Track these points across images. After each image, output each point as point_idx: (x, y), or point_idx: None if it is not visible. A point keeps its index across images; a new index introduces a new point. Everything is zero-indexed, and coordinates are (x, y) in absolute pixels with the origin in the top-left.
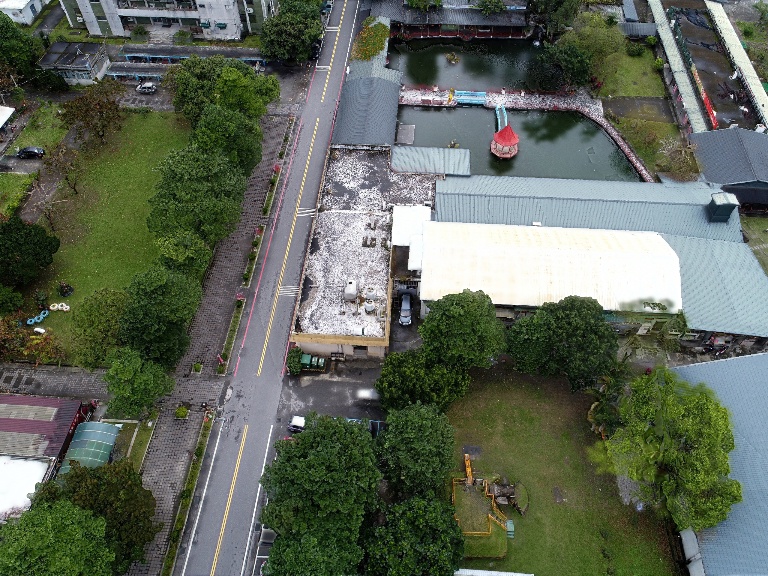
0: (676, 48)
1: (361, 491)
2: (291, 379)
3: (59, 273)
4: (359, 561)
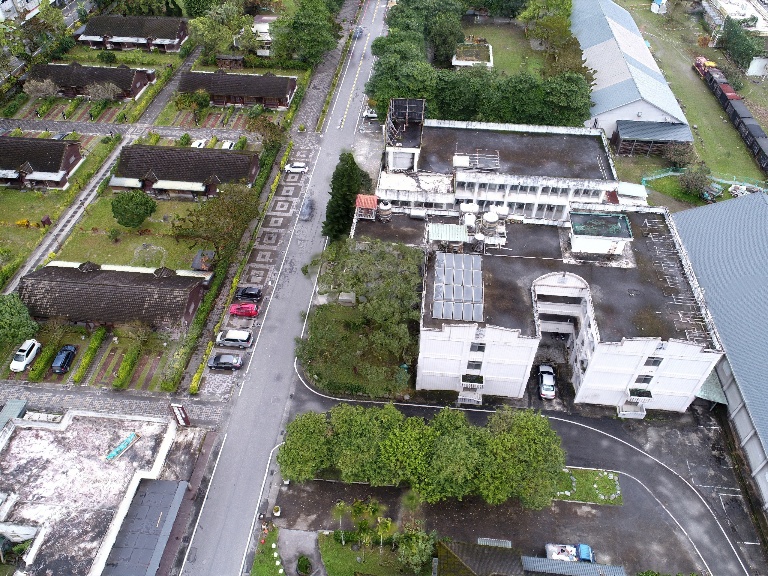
0: None
1: (425, 9)
2: None
3: None
4: (425, 23)
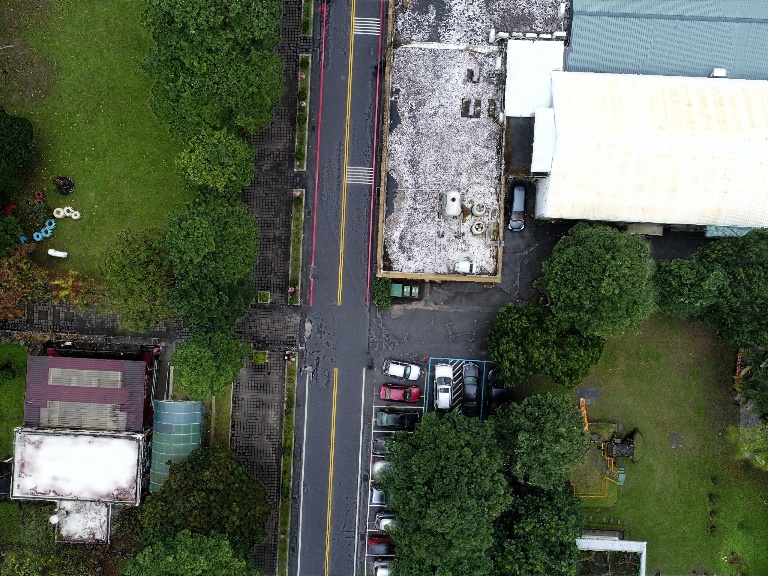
0: None
1: None
2: (379, 309)
3: (44, 154)
4: (489, 572)
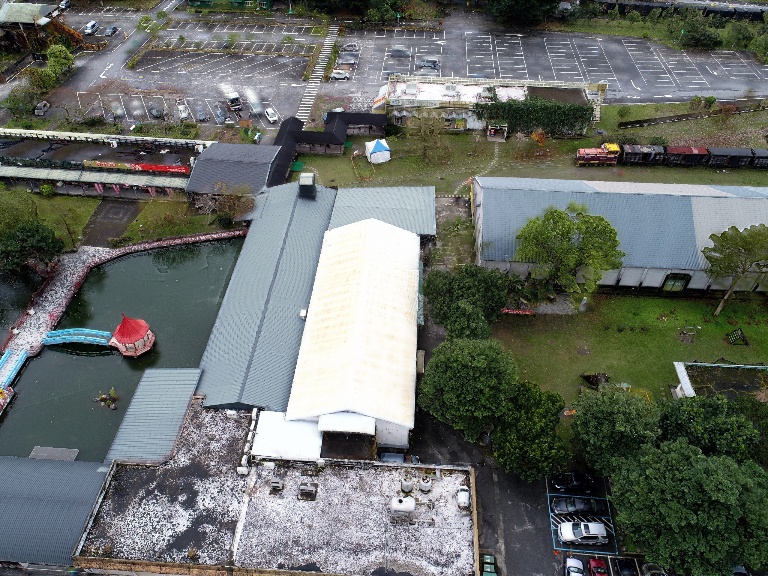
0: (38, 169)
1: None
2: None
3: None
4: None
